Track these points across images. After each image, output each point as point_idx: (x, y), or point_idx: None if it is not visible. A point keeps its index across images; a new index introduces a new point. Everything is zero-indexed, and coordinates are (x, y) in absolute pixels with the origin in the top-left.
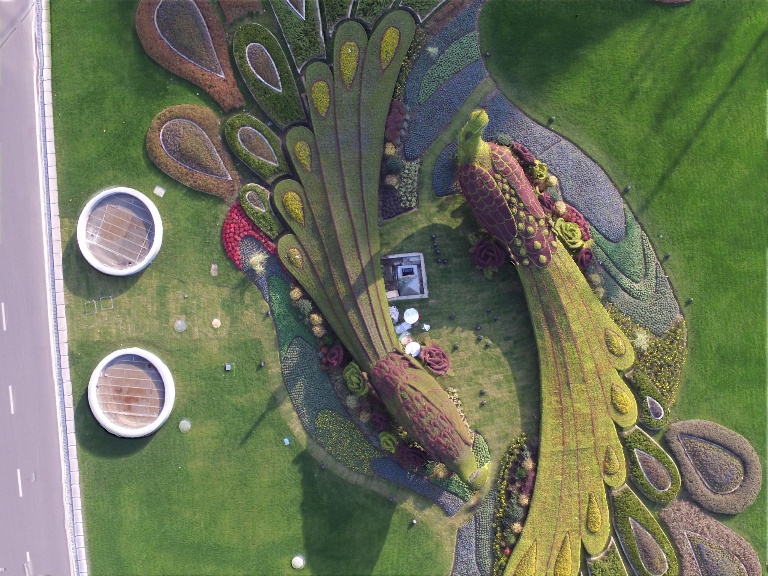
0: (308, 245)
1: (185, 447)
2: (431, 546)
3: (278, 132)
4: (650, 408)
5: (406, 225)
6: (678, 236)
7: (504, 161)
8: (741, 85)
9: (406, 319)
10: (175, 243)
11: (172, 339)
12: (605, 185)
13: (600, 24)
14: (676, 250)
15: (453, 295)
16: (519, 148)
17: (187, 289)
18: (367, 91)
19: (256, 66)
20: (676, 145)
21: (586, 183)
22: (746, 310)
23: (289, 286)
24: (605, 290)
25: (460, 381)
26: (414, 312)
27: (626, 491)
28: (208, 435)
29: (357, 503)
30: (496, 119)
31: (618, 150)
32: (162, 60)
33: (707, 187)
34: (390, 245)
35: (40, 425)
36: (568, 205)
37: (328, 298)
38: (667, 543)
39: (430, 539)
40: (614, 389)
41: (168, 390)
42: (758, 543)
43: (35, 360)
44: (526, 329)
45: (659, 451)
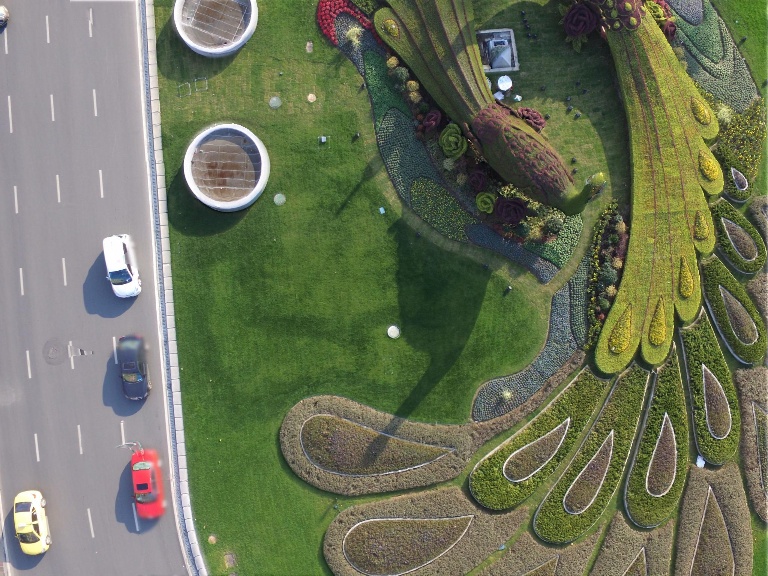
0: (404, 15)
1: (280, 220)
2: (526, 313)
3: None
4: (735, 179)
5: (496, 2)
6: (752, 22)
7: None
8: None
9: (500, 85)
10: (270, 24)
11: (267, 115)
12: None
13: None
14: (751, 35)
15: (543, 68)
16: None
17: (282, 67)
18: None
19: None
20: None
21: None
22: None
23: (385, 57)
24: (687, 67)
25: None
26: (508, 79)
27: (715, 259)
28: (303, 207)
29: (453, 270)
30: None
31: None
32: None
33: None
34: (481, 21)
35: (133, 204)
36: None
37: (425, 63)
38: (756, 313)
39: (525, 306)
40: (702, 155)
41: (265, 161)
42: None
43: (128, 143)
44: (614, 102)
45: (745, 221)
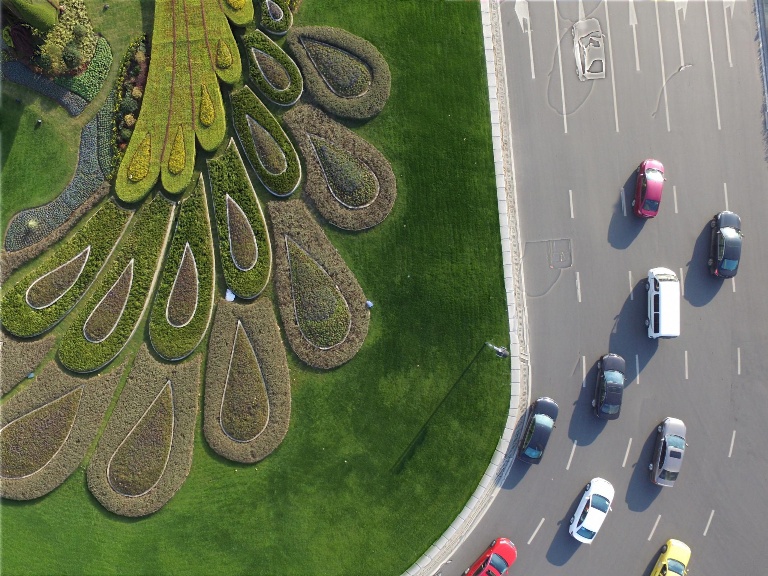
0: None
1: None
2: (56, 146)
3: None
4: (269, 10)
5: None
6: None
7: None
8: None
9: None
10: None
11: None
12: None
13: None
14: None
15: None
16: None
17: None
18: None
19: None
20: None
21: None
22: None
23: None
24: None
25: None
26: None
27: (244, 89)
28: None
29: None
30: None
31: None
32: None
33: None
34: None
35: None
36: None
37: None
38: (288, 143)
39: (55, 139)
40: None
41: None
42: (391, 153)
43: None
44: None
45: (278, 51)
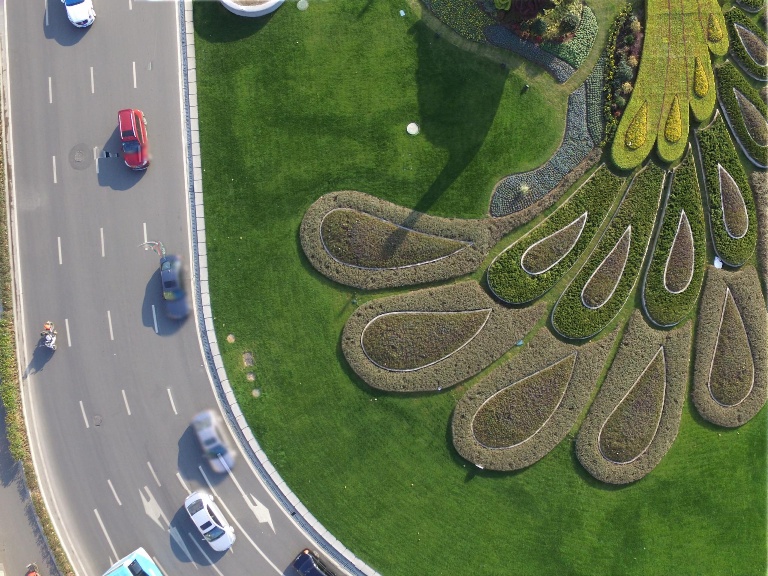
0: None
1: (303, 24)
2: (543, 112)
3: None
4: None
5: None
6: None
7: None
8: None
9: None
10: None
11: None
12: None
13: None
14: None
15: None
16: None
17: None
18: None
19: None
20: None
21: None
22: None
23: None
24: None
25: None
26: None
27: (729, 63)
28: (326, 11)
29: (471, 69)
30: None
31: None
32: None
33: None
34: None
35: (160, 13)
36: None
37: None
38: None
39: (542, 105)
40: None
41: None
42: None
43: None
44: None
45: (758, 28)
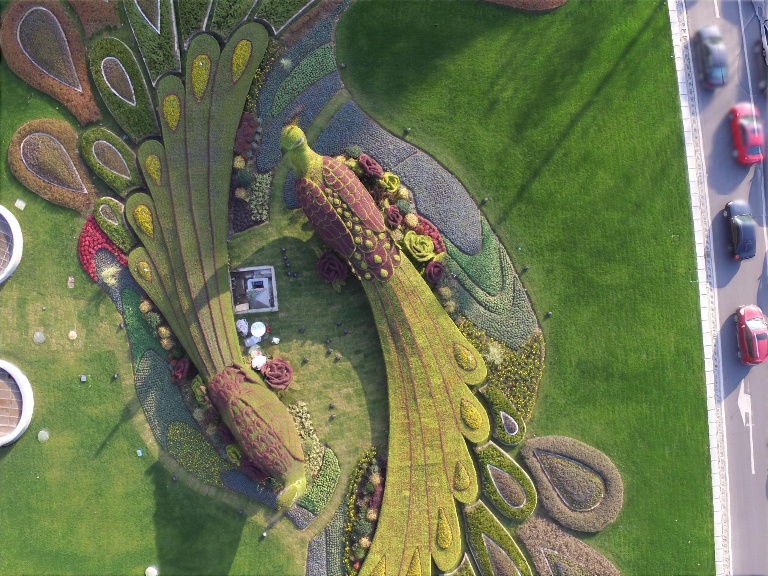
0: (156, 258)
1: (43, 457)
2: (282, 559)
3: (133, 146)
4: (504, 423)
5: (257, 238)
6: (537, 249)
7: (335, 175)
8: (608, 93)
9: (253, 332)
10: (34, 256)
11: (31, 350)
12: (461, 197)
13: (460, 33)
14: (535, 263)
15: (303, 308)
16: (363, 161)
17: (45, 301)
18: (217, 104)
19: (111, 80)
20: (537, 156)
21: (441, 195)
22: (608, 324)
23: (140, 299)
24: (459, 304)
25: (310, 395)
26: (261, 325)
27: (479, 507)
28: (65, 445)
29: (208, 515)
30: (350, 131)
31: (476, 161)
32: (23, 75)
33: (569, 198)
34: (241, 258)
35: None
36: (422, 217)
37: (174, 311)
38: (522, 560)
39: (281, 552)
40: (463, 404)
41: (25, 401)
42: (621, 562)
43: None
44: (377, 343)
45: (513, 467)
